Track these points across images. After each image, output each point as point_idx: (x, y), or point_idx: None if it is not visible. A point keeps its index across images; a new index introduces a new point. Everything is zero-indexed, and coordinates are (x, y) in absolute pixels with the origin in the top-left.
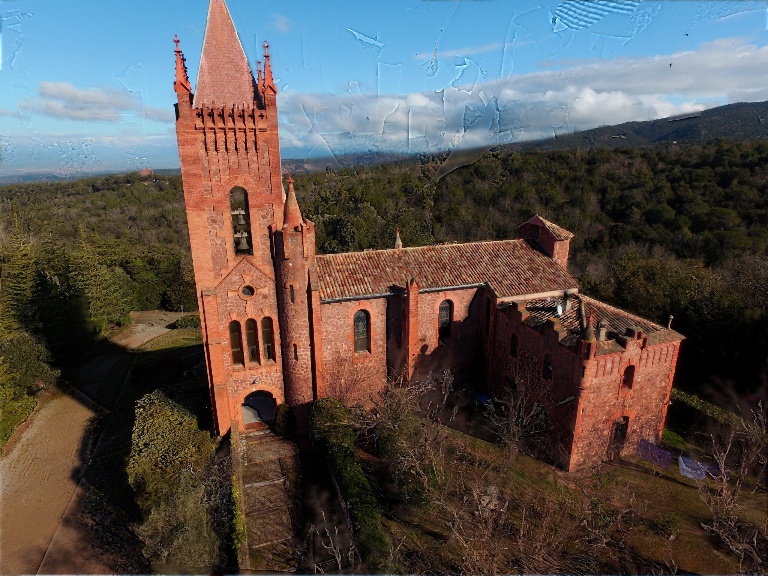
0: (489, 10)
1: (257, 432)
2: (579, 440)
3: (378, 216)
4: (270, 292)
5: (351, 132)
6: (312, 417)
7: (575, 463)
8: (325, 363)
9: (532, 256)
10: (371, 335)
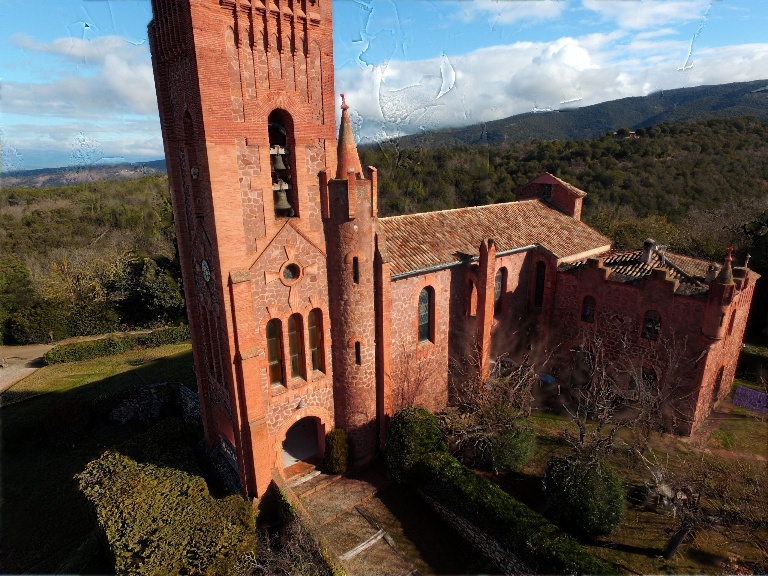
0: None
1: (303, 478)
2: (699, 399)
3: None
4: (319, 271)
5: None
6: (399, 438)
7: (693, 425)
8: None
9: (555, 216)
10: (435, 319)
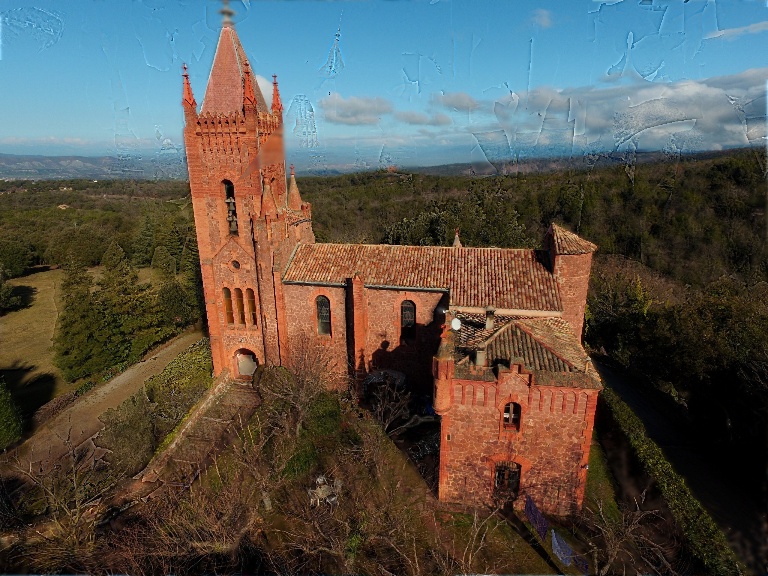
0: (418, 4)
1: None
2: (449, 469)
3: (478, 217)
4: (252, 268)
5: (515, 130)
6: None
7: (447, 494)
8: (291, 337)
9: (529, 269)
10: (331, 320)
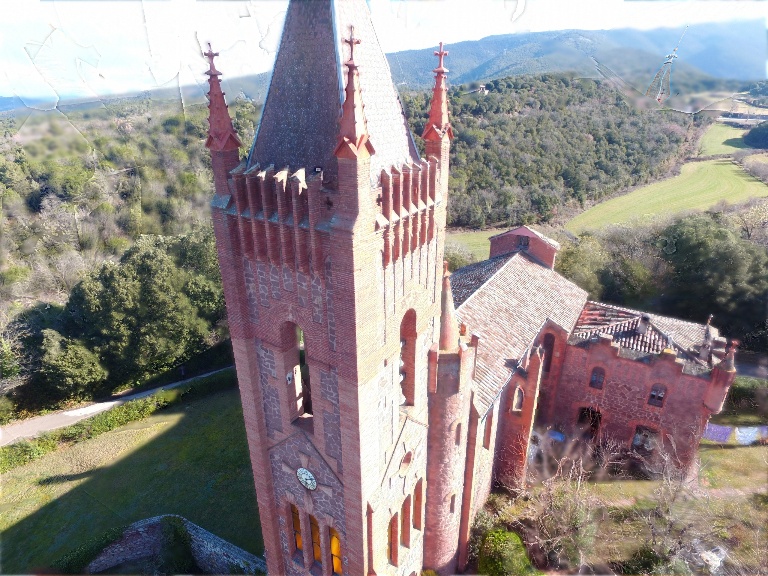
0: None
1: None
2: None
3: None
4: (422, 444)
5: None
6: (500, 575)
7: None
8: None
9: (539, 272)
10: (491, 429)
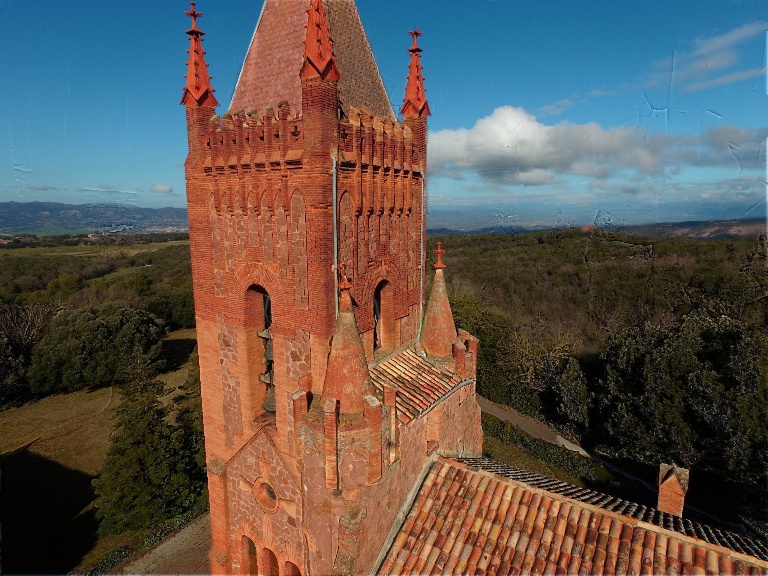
0: None
1: None
2: None
3: None
4: (300, 517)
5: None
6: None
7: None
8: None
9: None
10: None
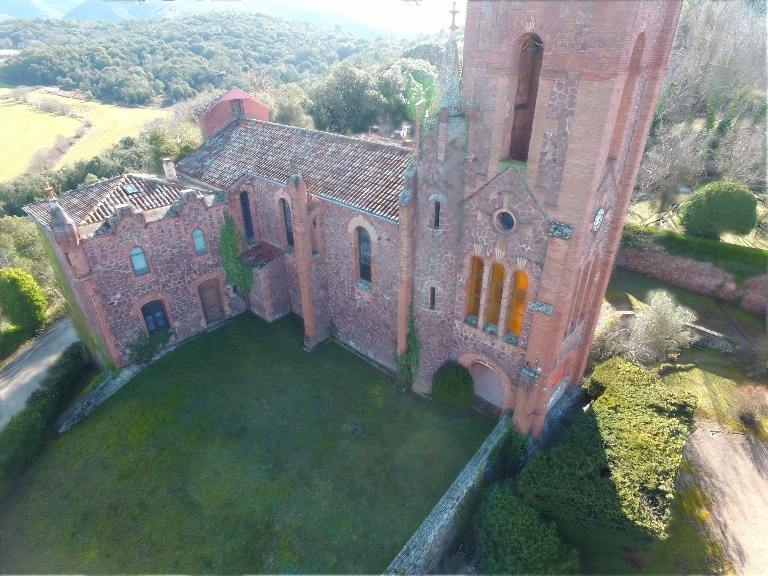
0: None
1: None
2: None
3: None
4: None
5: None
6: None
7: None
8: None
9: None
10: None
